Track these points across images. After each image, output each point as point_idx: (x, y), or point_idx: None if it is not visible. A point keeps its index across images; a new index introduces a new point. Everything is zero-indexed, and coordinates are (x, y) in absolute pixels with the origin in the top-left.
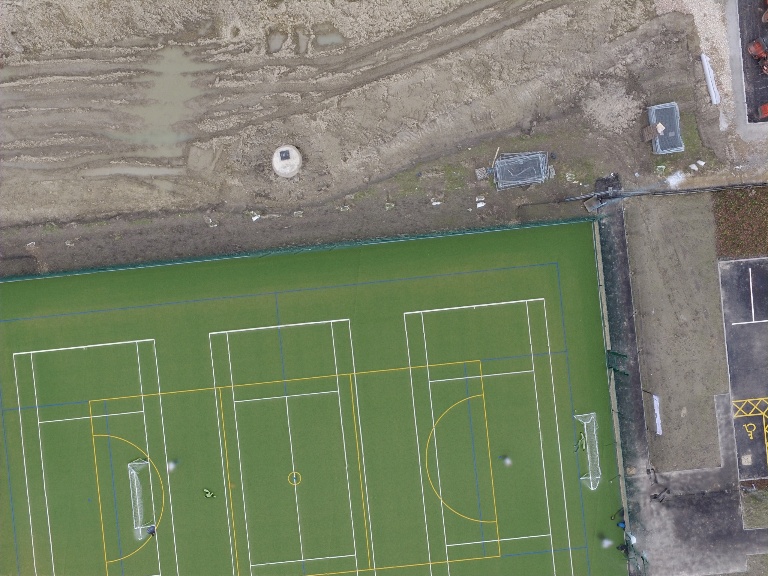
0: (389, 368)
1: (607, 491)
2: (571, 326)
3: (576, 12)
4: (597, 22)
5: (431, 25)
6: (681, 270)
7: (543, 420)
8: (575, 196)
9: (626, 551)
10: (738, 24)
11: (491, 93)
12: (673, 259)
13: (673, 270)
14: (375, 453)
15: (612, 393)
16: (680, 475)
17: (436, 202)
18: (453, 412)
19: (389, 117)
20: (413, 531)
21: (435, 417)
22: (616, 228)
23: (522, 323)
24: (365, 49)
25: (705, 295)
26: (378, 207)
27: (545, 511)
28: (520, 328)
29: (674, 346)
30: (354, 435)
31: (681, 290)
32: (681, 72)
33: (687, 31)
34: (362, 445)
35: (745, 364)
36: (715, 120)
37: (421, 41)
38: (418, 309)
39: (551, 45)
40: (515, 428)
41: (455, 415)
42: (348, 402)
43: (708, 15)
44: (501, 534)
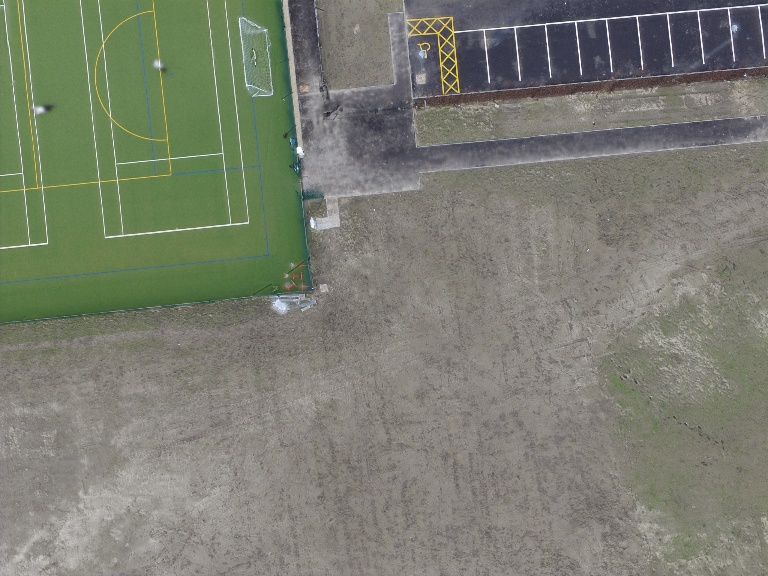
0: None
1: (280, 109)
2: None
3: None
4: None
5: None
6: None
7: (215, 37)
8: None
9: None
10: None
11: None
12: None
13: None
14: (42, 69)
15: (285, 10)
16: (353, 92)
17: None
18: (123, 28)
19: None
20: (82, 149)
21: (104, 33)
22: None
23: None
24: None
25: None
26: None
27: (217, 129)
28: None
29: None
30: (21, 51)
31: None
32: None
33: None
34: (29, 61)
35: None
36: None
37: None
38: None
39: None
40: (186, 45)
41: (125, 31)
42: (14, 17)
43: None
44: (172, 152)
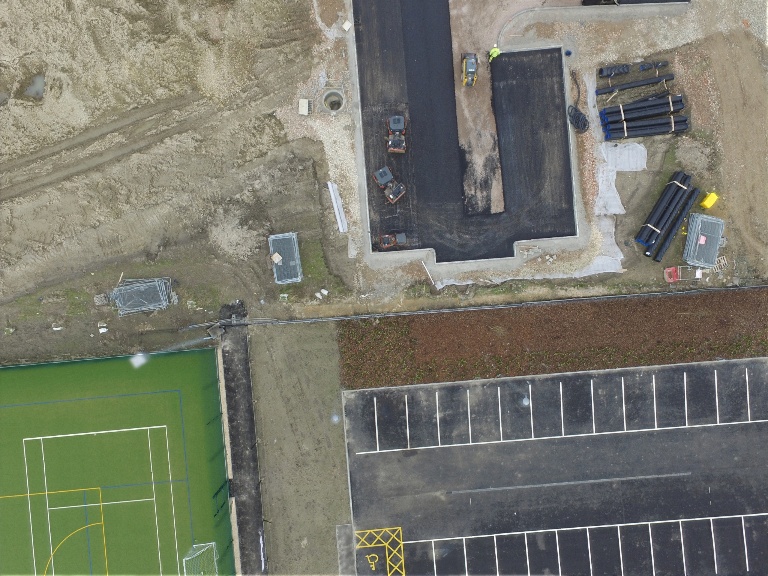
0: (7, 495)
1: None
2: (193, 454)
3: (205, 137)
4: (225, 147)
5: (57, 148)
6: (304, 399)
7: (163, 549)
8: (199, 323)
9: None
10: (363, 153)
11: (119, 217)
12: (296, 388)
13: (296, 399)
14: None
15: (233, 522)
16: None
17: (56, 328)
18: (72, 540)
19: (14, 240)
20: None
21: (53, 545)
22: (240, 356)
23: (143, 450)
24: None
25: (328, 424)
26: None
27: None
28: (141, 456)
29: (295, 476)
30: None
31: (304, 419)
32: (307, 200)
33: (315, 158)
34: None
35: (369, 494)
36: (344, 247)
37: (45, 164)
38: (38, 435)
39: (179, 169)
40: (134, 557)
41: (74, 543)
42: None
43: (338, 142)
44: None
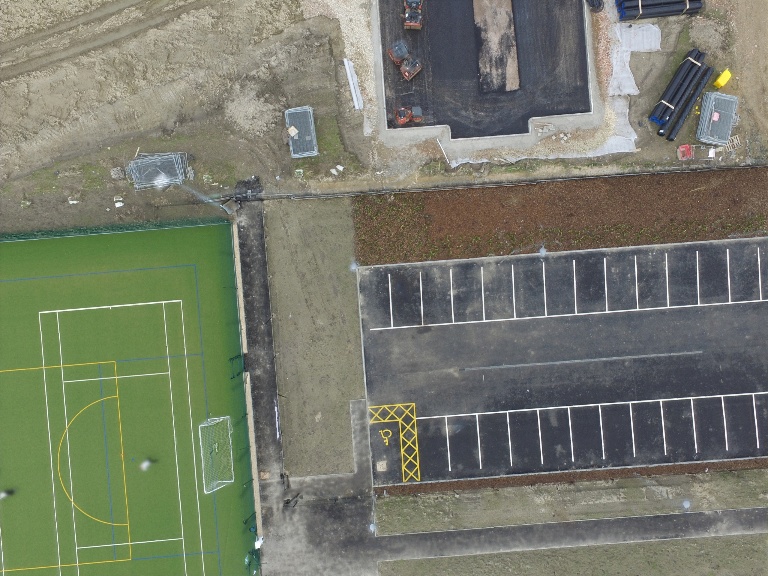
0: (23, 367)
1: (240, 495)
2: (208, 328)
3: (221, 14)
4: (242, 24)
5: (74, 23)
6: (319, 274)
7: (177, 423)
8: (214, 198)
9: (256, 556)
10: (379, 30)
11: (135, 93)
12: (311, 263)
13: (311, 274)
14: (6, 453)
15: (248, 397)
16: (313, 480)
17: (72, 201)
18: (87, 413)
19: (30, 114)
20: (43, 533)
21: (68, 418)
22: (255, 231)
23: (158, 325)
24: (7, 45)
25: (343, 300)
26: (14, 205)
27: (177, 514)
28: (156, 330)
29: (310, 350)
30: None
31: (319, 294)
32: (323, 76)
33: (331, 35)
34: None
35: (383, 370)
36: (360, 125)
37: (62, 39)
38: (53, 308)
39: (196, 46)
40: (149, 430)
41: (88, 416)
42: None
43: (354, 20)
44: (132, 537)
